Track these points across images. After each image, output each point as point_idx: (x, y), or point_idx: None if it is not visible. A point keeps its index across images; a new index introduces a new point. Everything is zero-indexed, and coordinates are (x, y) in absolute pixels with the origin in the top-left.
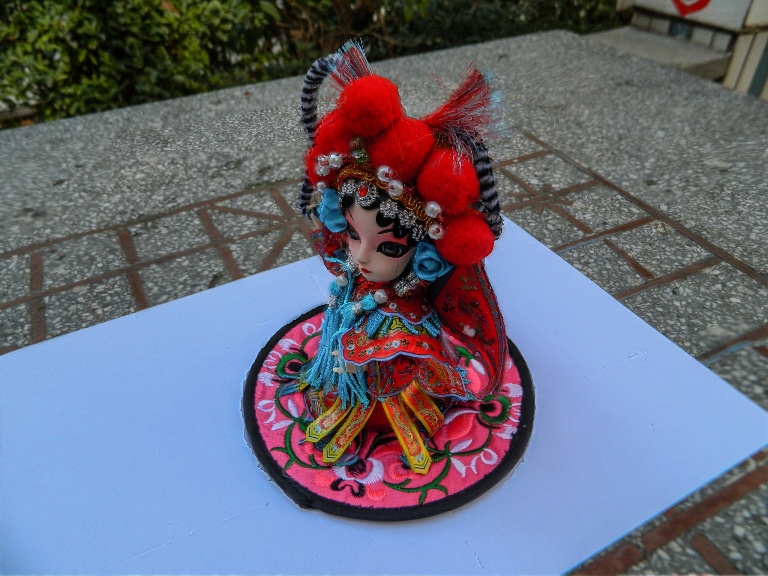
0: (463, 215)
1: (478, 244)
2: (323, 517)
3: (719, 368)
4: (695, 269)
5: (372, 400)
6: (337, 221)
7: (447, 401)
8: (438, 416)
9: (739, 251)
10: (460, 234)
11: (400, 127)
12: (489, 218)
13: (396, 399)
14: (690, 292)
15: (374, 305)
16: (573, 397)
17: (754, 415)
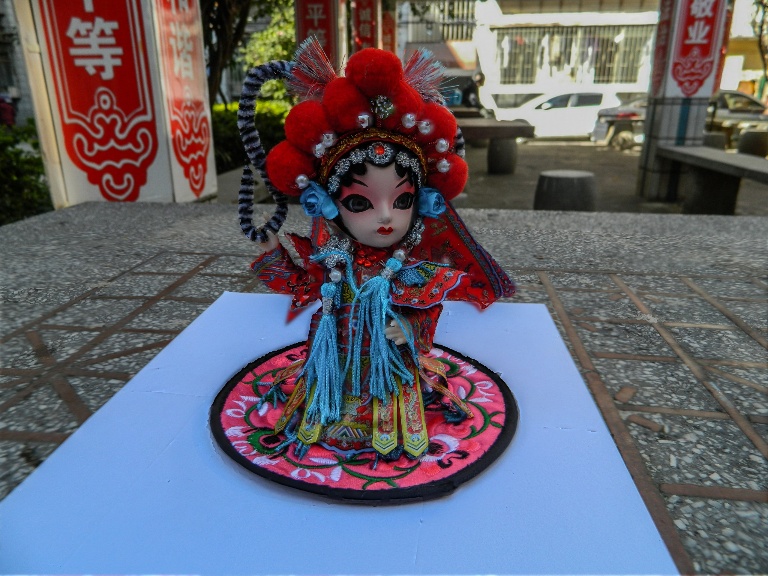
0: None
1: None
2: (469, 488)
3: None
4: None
5: (413, 374)
6: (329, 208)
7: None
8: None
9: None
10: (457, 163)
11: (404, 83)
12: (458, 153)
13: None
14: None
15: (401, 264)
16: (460, 342)
17: (526, 307)
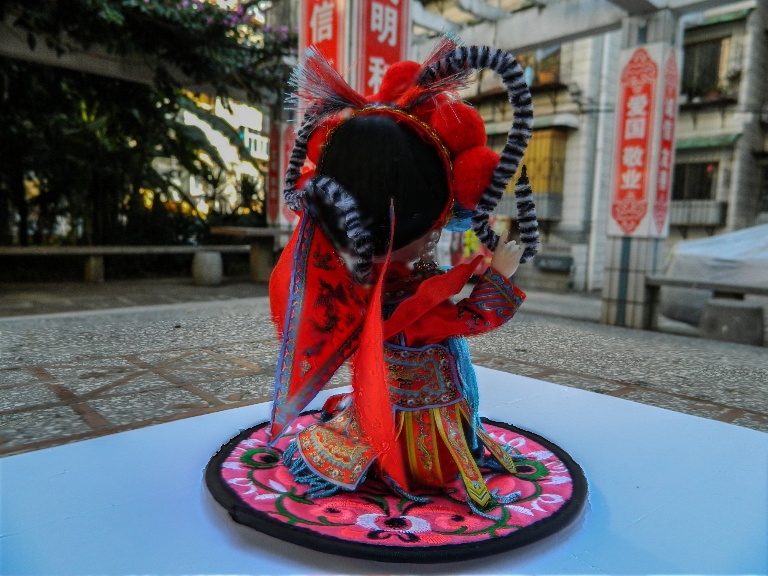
0: None
1: None
2: None
3: None
4: None
5: None
6: None
7: None
8: (328, 405)
9: None
10: None
11: None
12: None
13: None
14: None
15: None
16: (149, 484)
17: None
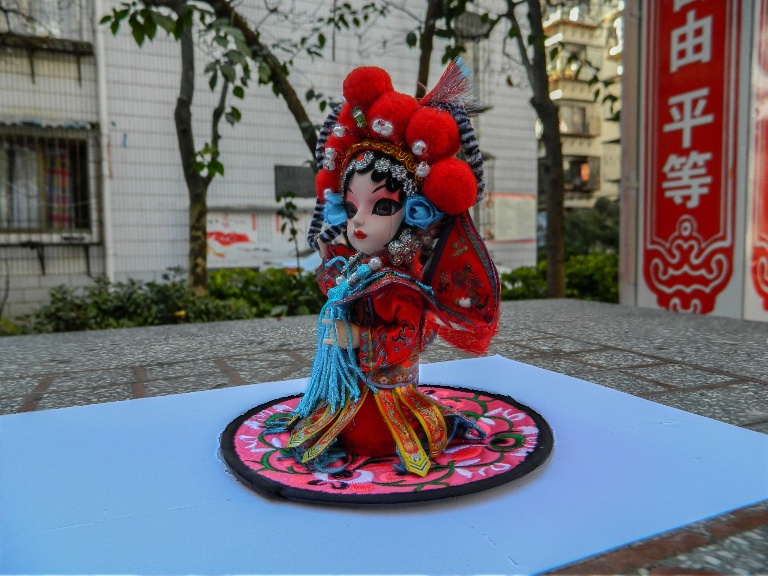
0: (446, 156)
1: (460, 175)
2: (294, 506)
3: (767, 431)
4: (721, 385)
5: (364, 391)
6: (339, 215)
7: (450, 423)
8: (438, 418)
9: (765, 377)
10: (444, 167)
11: (391, 93)
12: (469, 160)
13: (391, 396)
14: (719, 395)
15: (368, 269)
16: (599, 442)
17: None
